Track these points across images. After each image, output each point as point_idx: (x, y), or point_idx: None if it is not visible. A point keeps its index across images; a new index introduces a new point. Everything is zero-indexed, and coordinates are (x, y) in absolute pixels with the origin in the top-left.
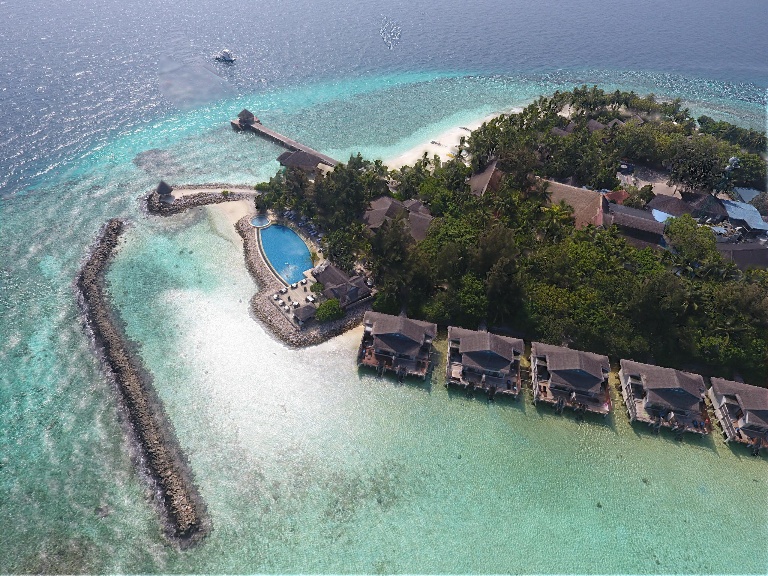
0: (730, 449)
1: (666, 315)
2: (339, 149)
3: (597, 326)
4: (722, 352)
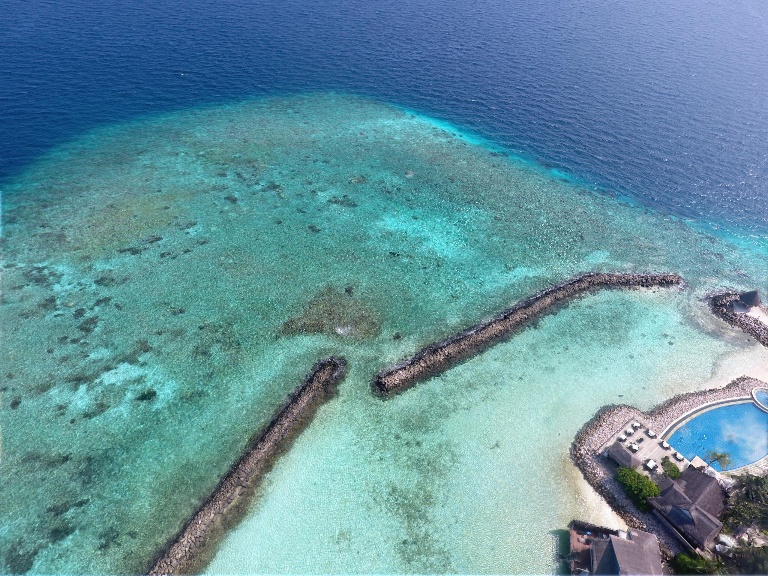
0: None
1: None
2: None
3: None
4: None
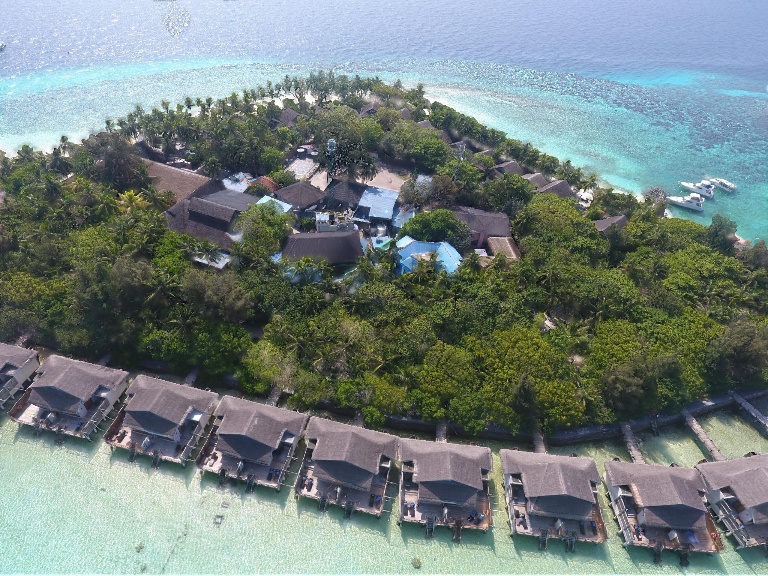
0: (111, 454)
1: (95, 306)
2: (17, 134)
3: (47, 318)
4: (164, 347)
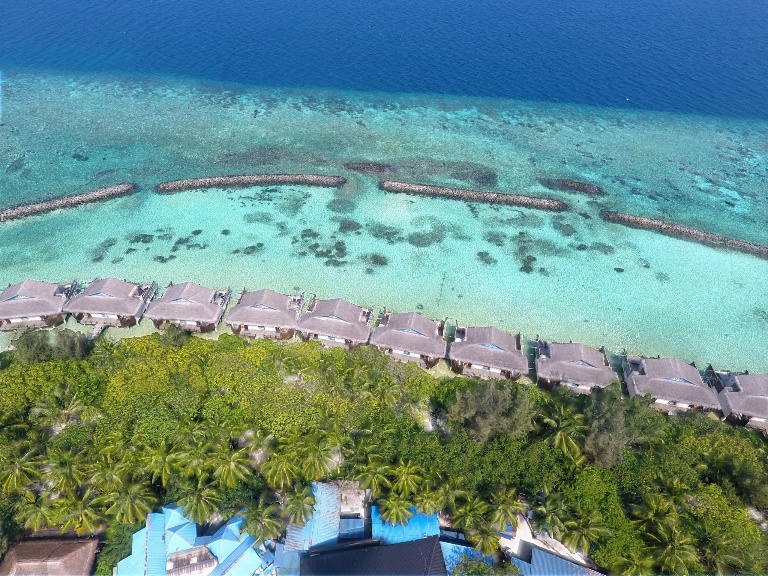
0: None
1: None
2: None
3: None
4: (519, 385)
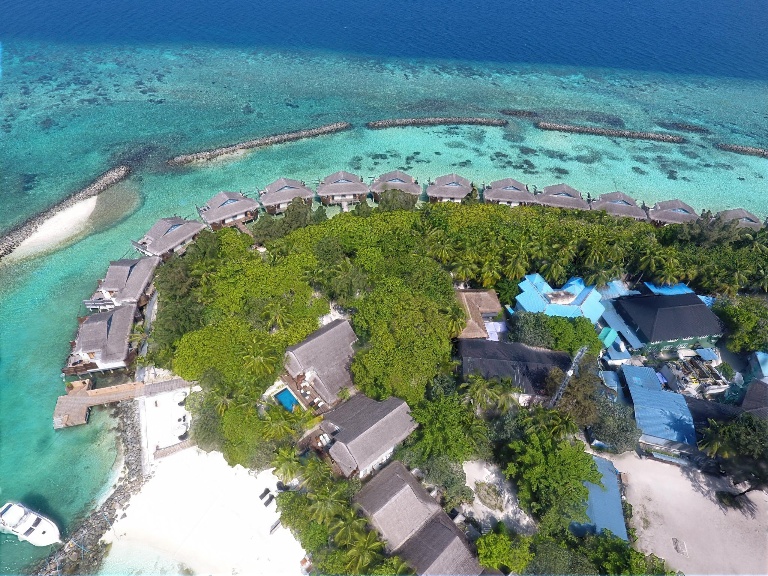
0: None
1: None
2: None
3: None
4: None
